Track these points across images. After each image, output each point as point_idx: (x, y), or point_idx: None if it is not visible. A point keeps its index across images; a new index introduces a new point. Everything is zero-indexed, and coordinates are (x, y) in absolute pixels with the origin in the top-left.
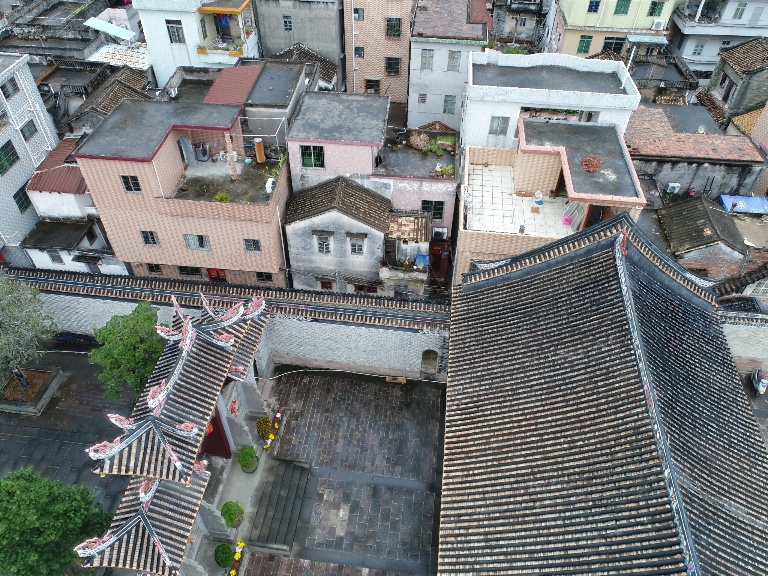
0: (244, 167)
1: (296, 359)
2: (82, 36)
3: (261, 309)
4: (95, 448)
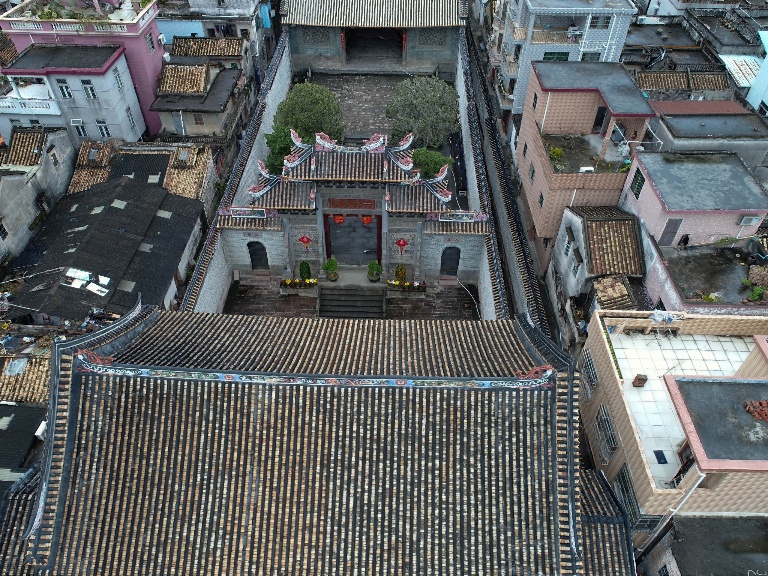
0: (618, 162)
1: (480, 291)
2: (754, 41)
3: (447, 200)
4: (293, 132)
